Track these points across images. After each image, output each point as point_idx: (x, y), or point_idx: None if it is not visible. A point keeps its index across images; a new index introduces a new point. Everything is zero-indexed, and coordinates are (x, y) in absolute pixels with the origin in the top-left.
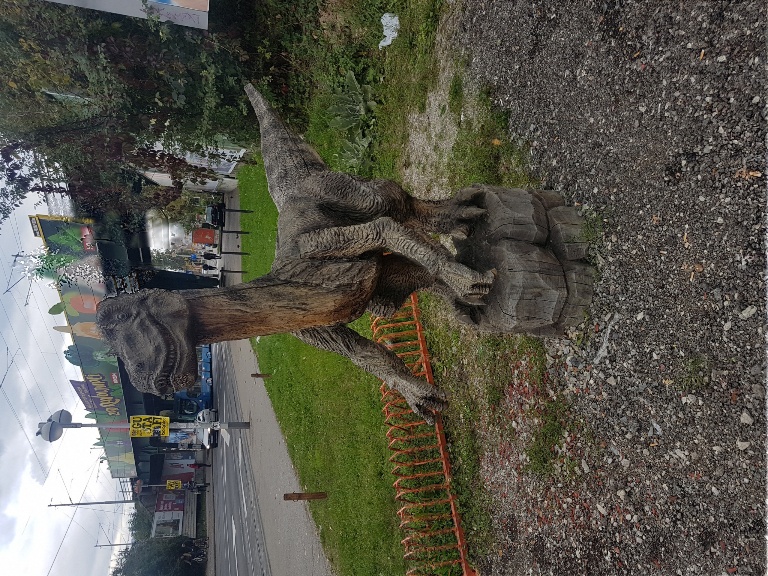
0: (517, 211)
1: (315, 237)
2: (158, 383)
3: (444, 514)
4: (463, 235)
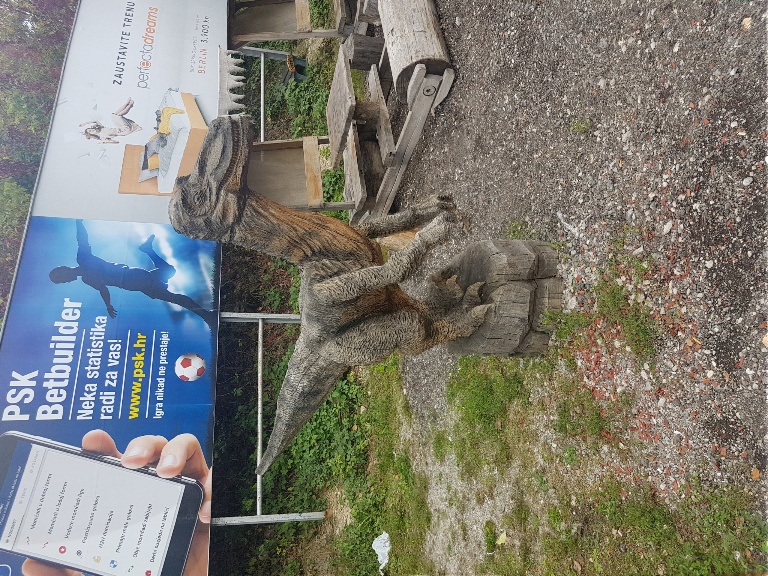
0: None
1: None
2: None
3: None
4: None
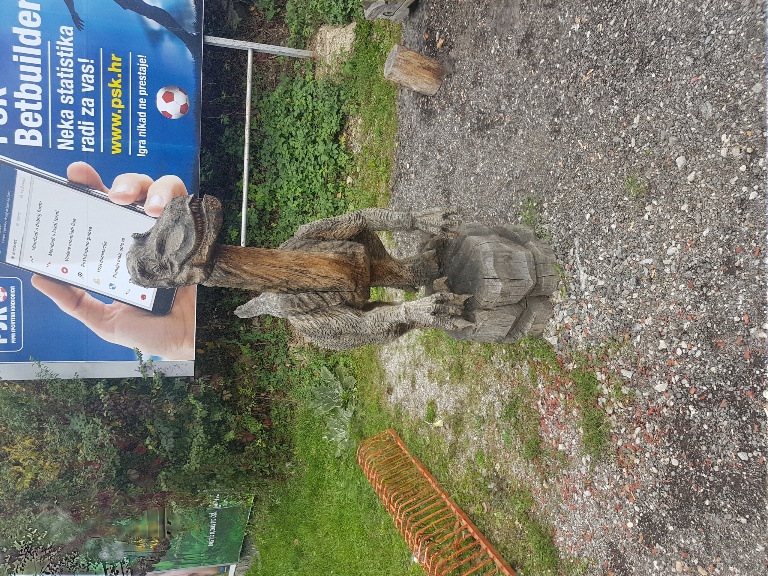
0: None
1: (308, 223)
2: (192, 207)
3: None
4: (432, 250)
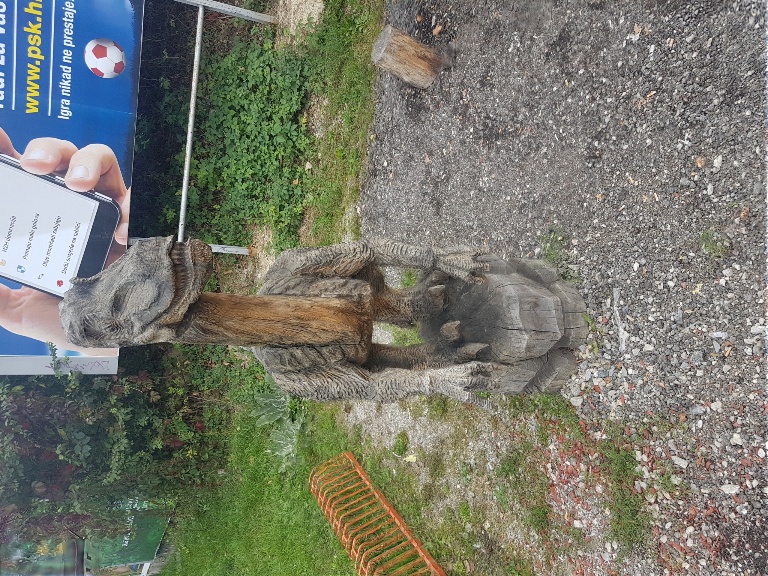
0: None
1: (303, 254)
2: (174, 257)
3: None
4: (440, 285)
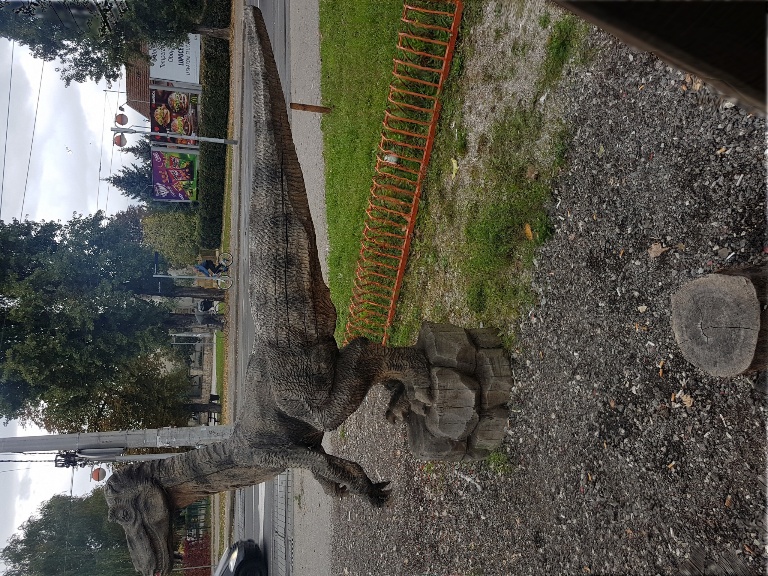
0: (448, 433)
1: None
2: None
3: (380, 329)
4: (401, 419)
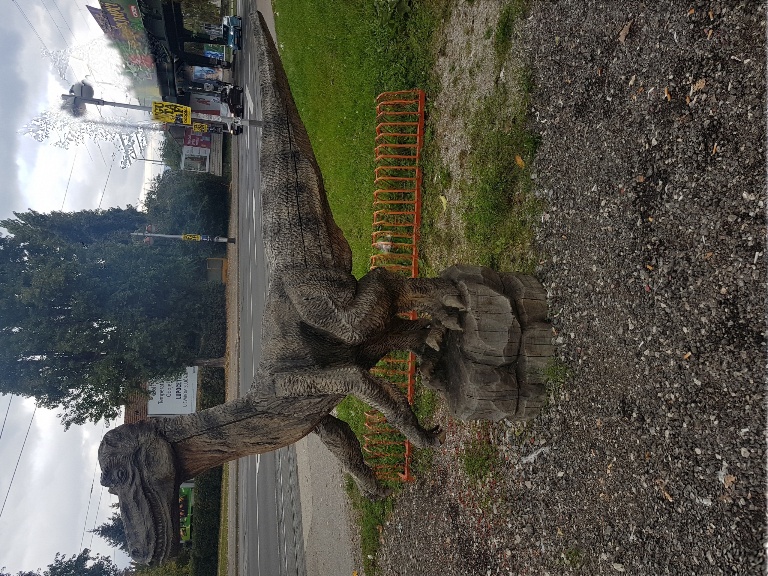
0: (490, 344)
1: (289, 389)
2: (151, 560)
3: None
4: (436, 348)
